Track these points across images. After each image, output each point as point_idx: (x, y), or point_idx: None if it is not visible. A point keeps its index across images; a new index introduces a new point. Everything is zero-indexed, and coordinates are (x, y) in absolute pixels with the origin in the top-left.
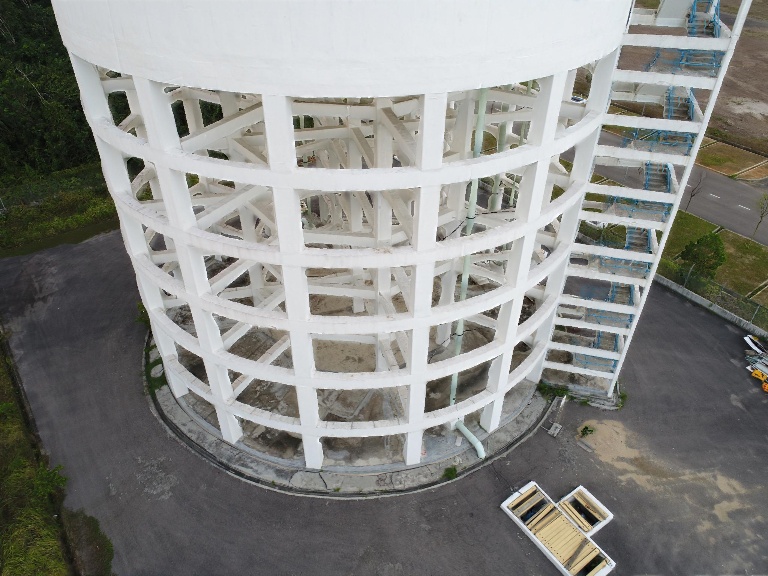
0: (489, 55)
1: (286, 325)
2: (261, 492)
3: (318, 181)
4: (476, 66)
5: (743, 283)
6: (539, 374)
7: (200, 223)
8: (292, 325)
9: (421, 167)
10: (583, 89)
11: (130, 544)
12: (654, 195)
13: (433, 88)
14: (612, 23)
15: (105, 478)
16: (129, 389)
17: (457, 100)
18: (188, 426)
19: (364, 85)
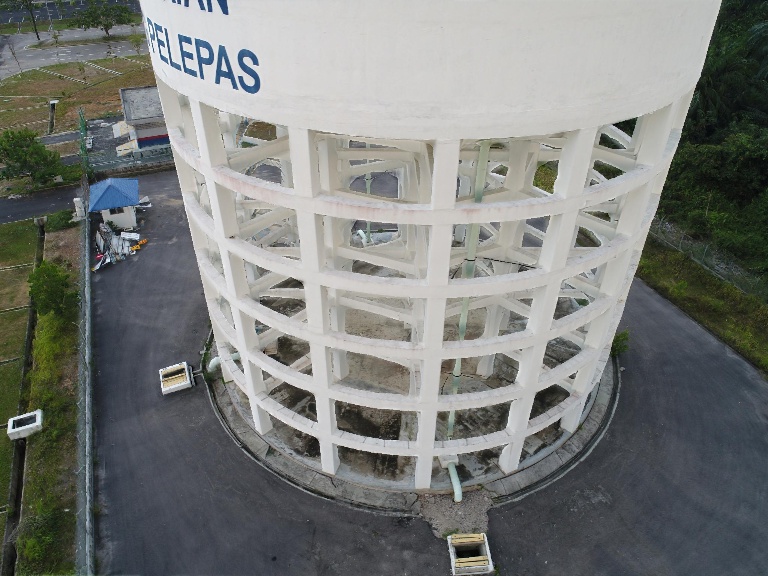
0: None
1: None
2: None
3: None
4: None
5: (5, 318)
6: None
7: None
8: None
9: None
10: None
11: None
12: None
13: None
14: None
15: None
16: None
17: None
18: None
19: None
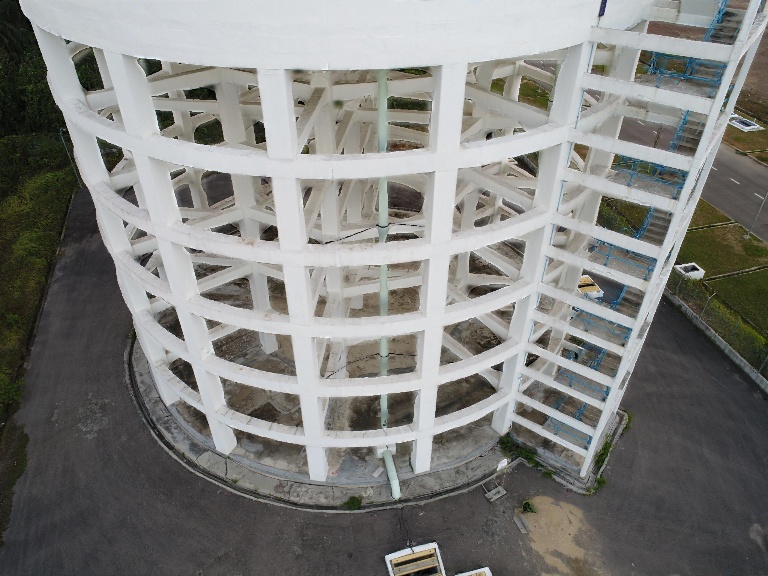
0: (333, 30)
1: (171, 299)
2: (168, 460)
3: (166, 152)
4: (317, 41)
5: None
6: (504, 426)
7: (115, 180)
8: (176, 301)
9: (268, 154)
10: (763, 113)
11: (40, 469)
12: (633, 243)
13: (265, 62)
14: (554, 9)
15: (55, 403)
16: (119, 329)
17: (426, 91)
18: (143, 377)
19: (189, 50)
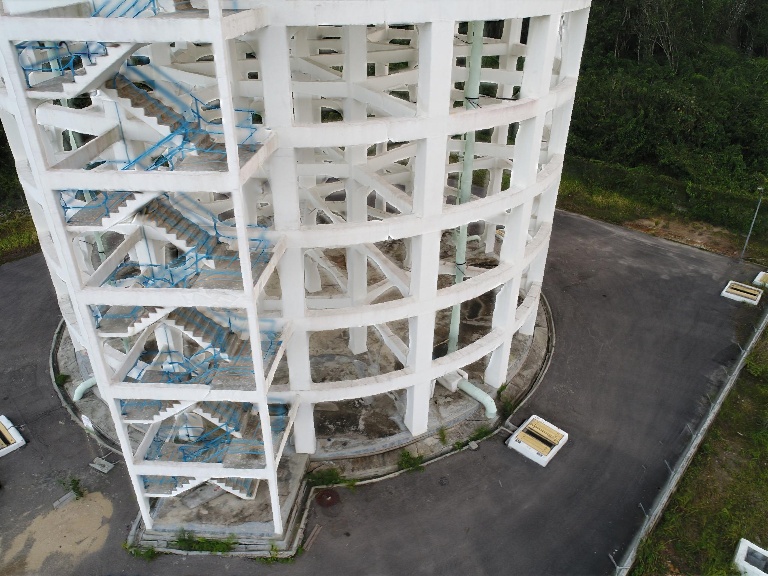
0: None
1: None
2: None
3: None
4: None
5: None
6: None
7: None
8: None
9: None
10: None
11: None
12: None
13: None
14: None
15: None
16: None
17: None
18: None
19: None
